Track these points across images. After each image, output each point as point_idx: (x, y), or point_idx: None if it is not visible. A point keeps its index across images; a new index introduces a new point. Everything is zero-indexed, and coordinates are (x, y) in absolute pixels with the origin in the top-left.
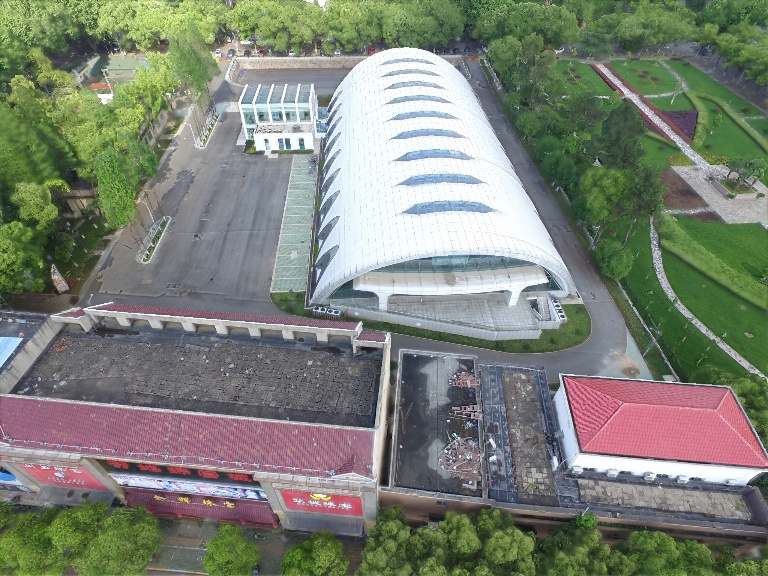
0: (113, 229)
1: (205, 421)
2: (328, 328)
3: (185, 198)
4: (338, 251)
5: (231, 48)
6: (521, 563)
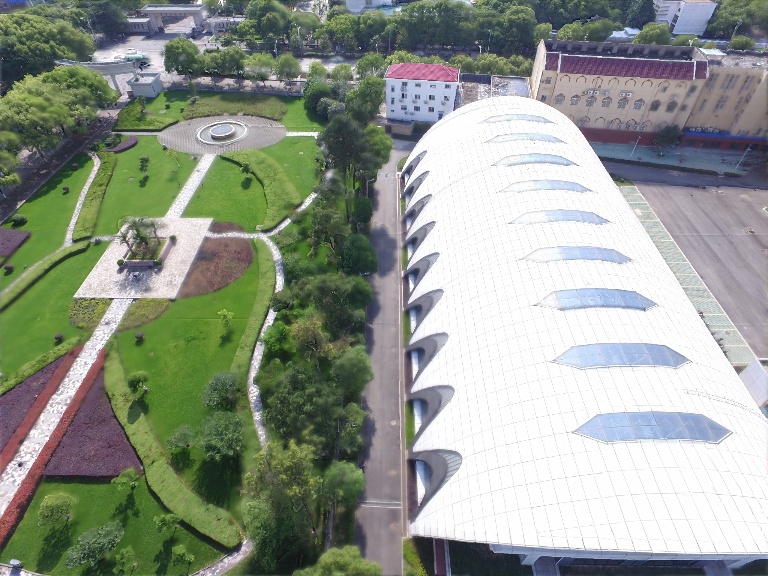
0: None
1: None
2: (574, 55)
3: None
4: None
5: None
6: None
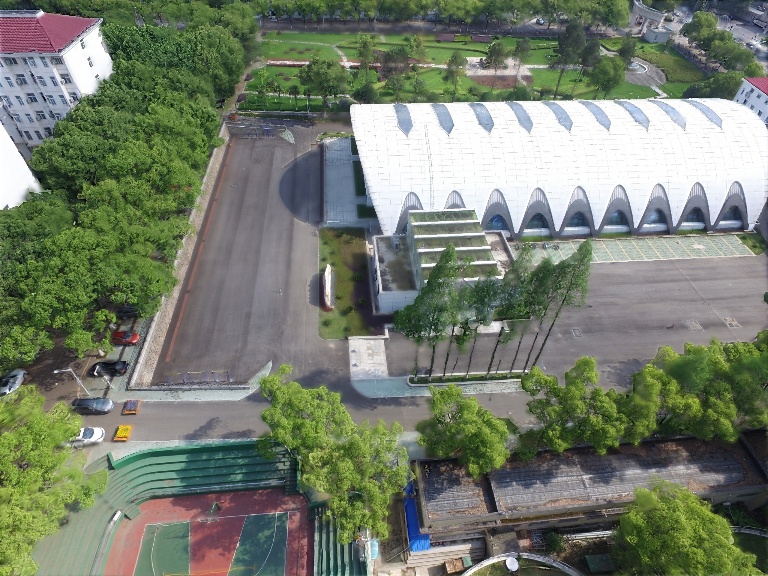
0: None
1: None
2: None
3: None
4: (741, 181)
5: None
6: None
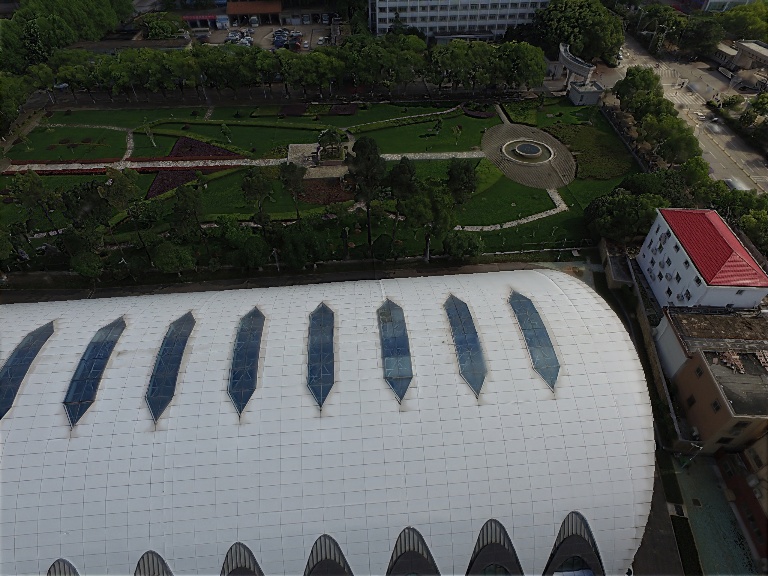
0: None
1: None
2: None
3: None
4: (585, 512)
5: None
6: None
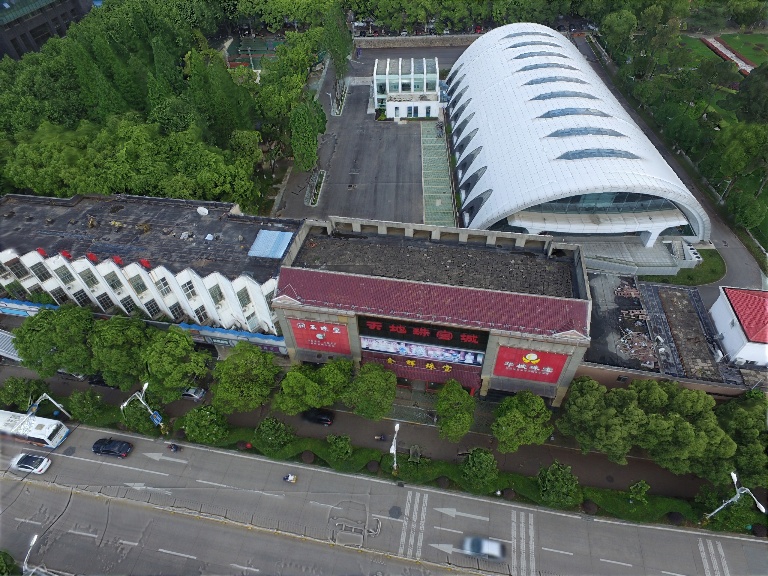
0: (280, 179)
1: (450, 291)
2: None
3: (333, 156)
4: (492, 193)
5: None
6: (706, 413)
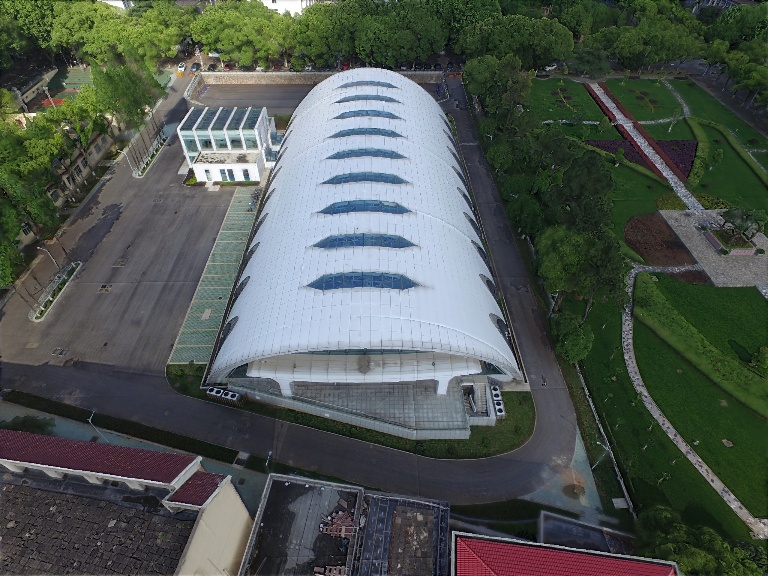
0: None
1: None
2: (136, 479)
3: (104, 239)
4: (236, 325)
5: (197, 61)
6: None
